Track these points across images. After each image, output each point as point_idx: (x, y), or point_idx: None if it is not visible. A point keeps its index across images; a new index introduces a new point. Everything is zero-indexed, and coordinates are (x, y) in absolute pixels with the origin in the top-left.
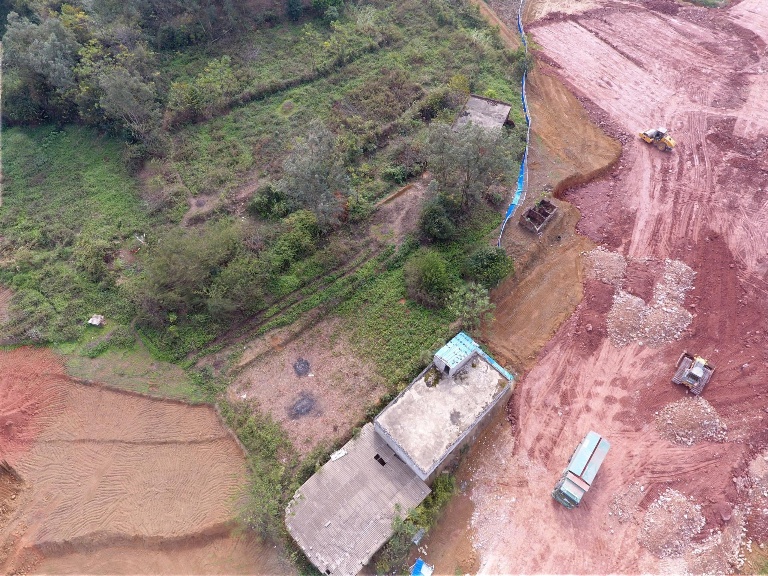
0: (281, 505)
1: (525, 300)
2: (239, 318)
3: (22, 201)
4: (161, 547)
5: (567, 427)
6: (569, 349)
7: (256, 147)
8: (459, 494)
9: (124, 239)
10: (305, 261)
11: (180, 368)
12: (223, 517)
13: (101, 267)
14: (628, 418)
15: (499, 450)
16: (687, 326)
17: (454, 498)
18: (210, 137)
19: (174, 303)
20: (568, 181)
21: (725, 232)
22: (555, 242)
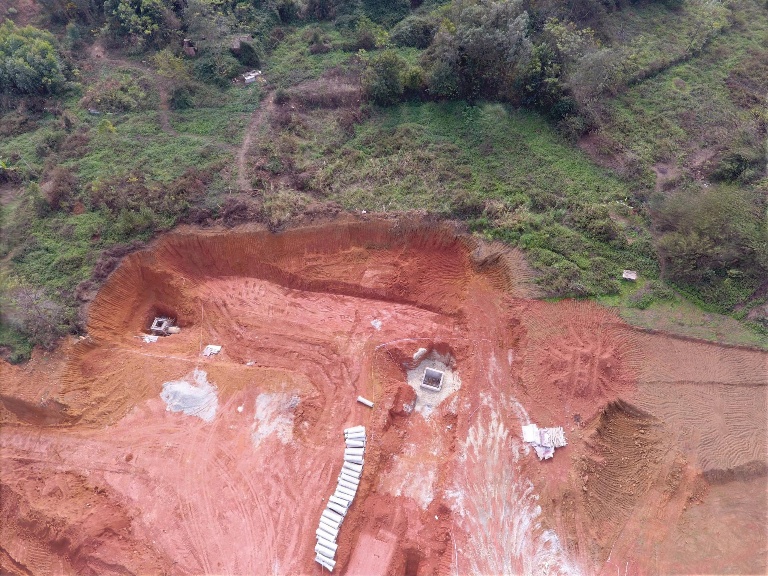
0: None
1: None
2: (766, 274)
3: (486, 168)
4: None
5: None
6: None
7: (680, 120)
8: None
9: (606, 203)
10: None
11: (733, 319)
12: None
13: (613, 227)
14: None
15: None
16: None
17: None
18: (631, 111)
19: None
20: None
21: None
22: None
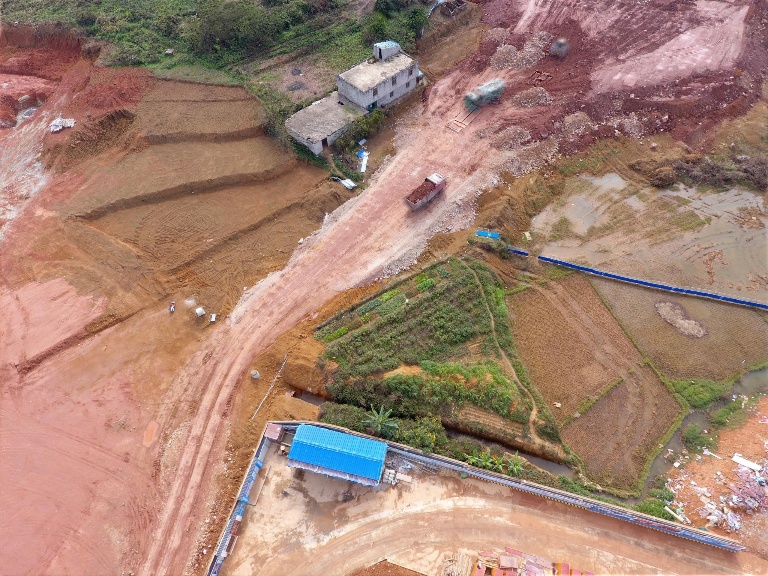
0: (283, 122)
1: (440, 51)
2: (258, 49)
3: (116, 0)
4: (215, 141)
5: (457, 104)
6: (465, 72)
7: None
8: (388, 129)
9: (183, 17)
10: (299, 26)
11: (222, 72)
12: (250, 126)
13: (171, 25)
14: (495, 99)
15: (414, 112)
16: (541, 58)
17: (385, 130)
18: None
19: None
20: None
21: (580, 20)
22: (465, 25)
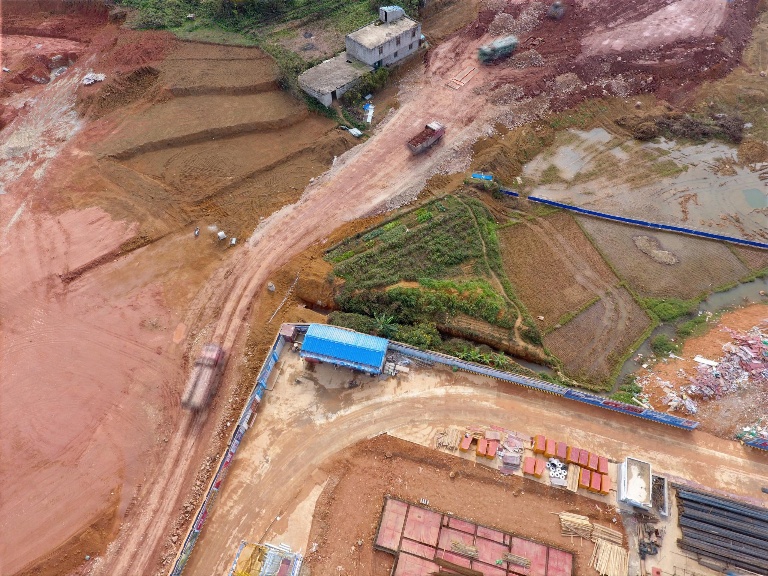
0: (296, 78)
1: (442, 18)
2: (272, 14)
3: None
4: (234, 94)
5: (457, 65)
6: (464, 37)
7: None
8: (392, 86)
9: None
10: None
11: (240, 34)
12: (266, 81)
13: None
14: (492, 61)
15: (417, 72)
16: (535, 25)
17: (389, 87)
18: None
19: None
20: None
21: None
22: None
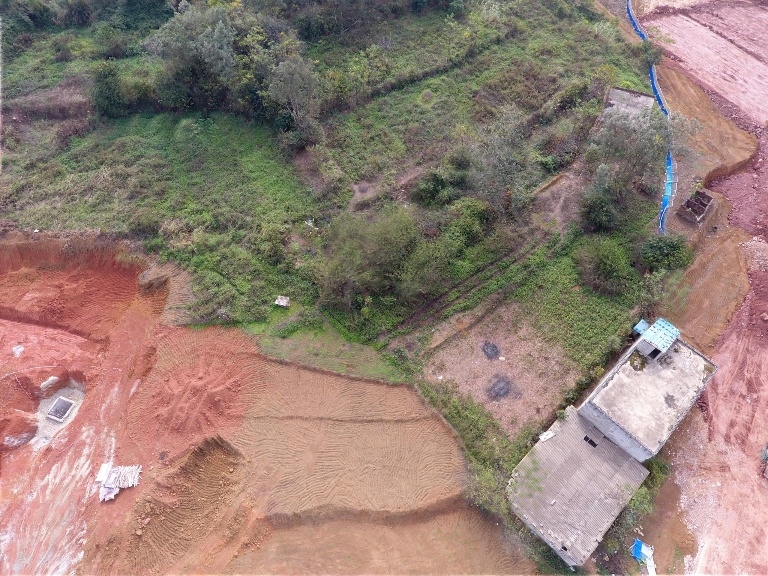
0: None
1: (693, 289)
2: (423, 301)
3: (186, 185)
4: (386, 521)
5: (758, 414)
6: (746, 338)
7: (406, 135)
8: None
9: (293, 223)
10: (475, 247)
11: (372, 349)
12: (445, 494)
13: (280, 250)
14: None
15: (695, 435)
16: None
17: None
18: (359, 125)
19: (360, 286)
20: (713, 173)
21: None
22: (711, 233)
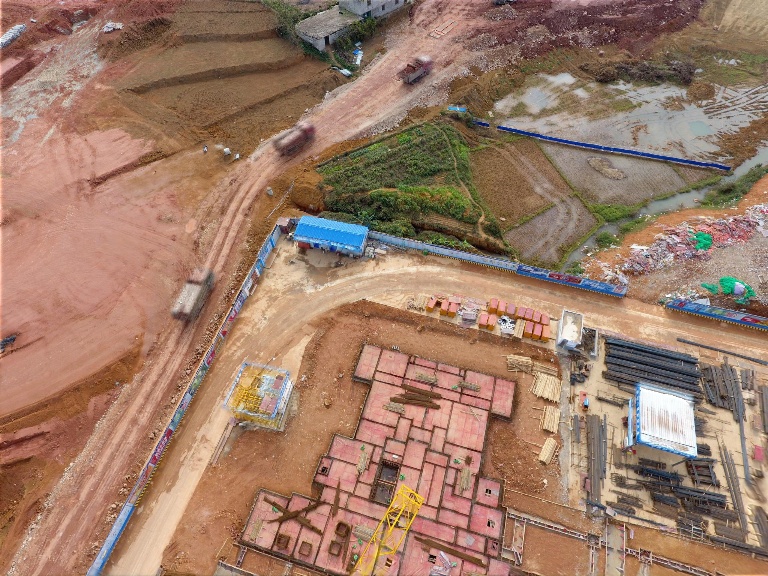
0: (293, 27)
1: None
2: None
3: None
4: (238, 41)
5: (439, 19)
6: None
7: None
8: None
9: None
10: None
11: None
12: (266, 29)
13: None
14: (470, 15)
15: (402, 24)
16: None
17: (377, 36)
18: None
19: None
20: None
21: None
22: None
